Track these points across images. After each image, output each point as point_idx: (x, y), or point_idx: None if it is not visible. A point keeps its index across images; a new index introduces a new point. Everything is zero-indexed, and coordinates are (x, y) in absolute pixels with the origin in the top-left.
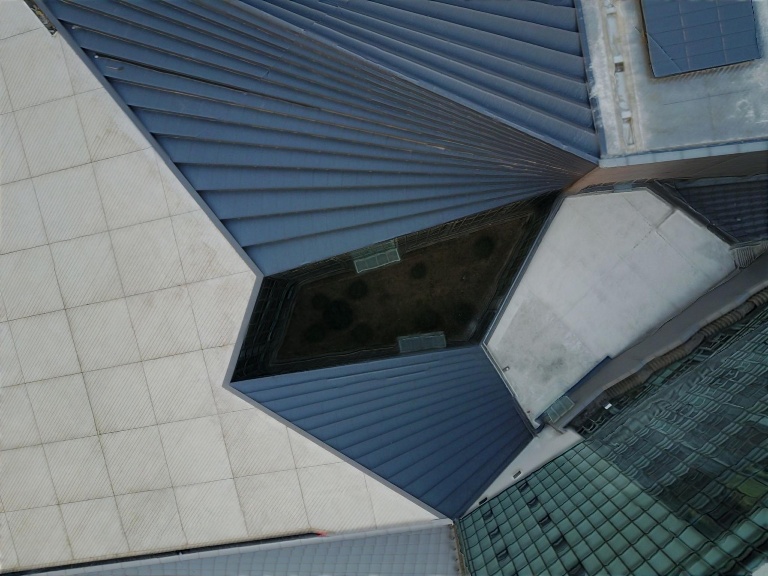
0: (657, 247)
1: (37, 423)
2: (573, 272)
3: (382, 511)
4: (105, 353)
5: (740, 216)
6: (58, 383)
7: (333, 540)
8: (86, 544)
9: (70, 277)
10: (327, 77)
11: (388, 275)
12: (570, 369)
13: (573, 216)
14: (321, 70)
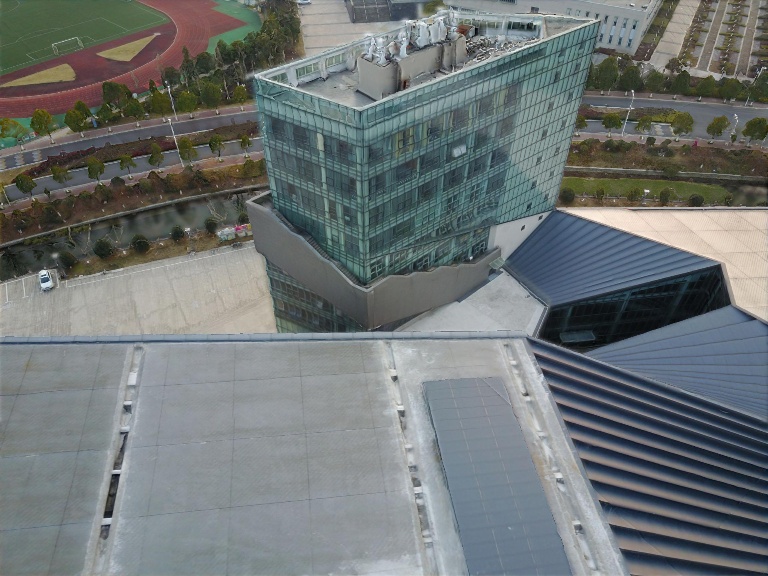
0: None
1: None
2: None
3: (598, 215)
4: None
5: None
6: None
7: None
8: (762, 216)
9: None
10: (755, 410)
11: None
12: (484, 296)
13: None
14: (763, 413)
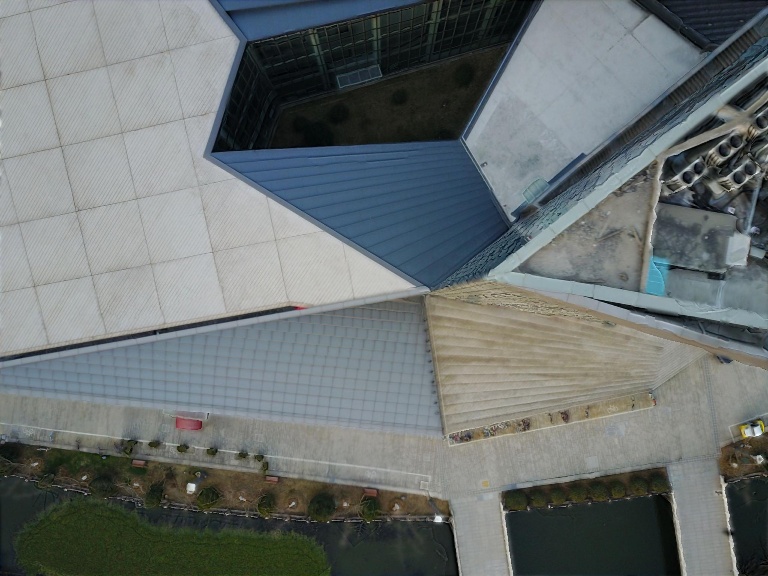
0: (632, 49)
1: (14, 201)
2: (551, 71)
3: (360, 281)
4: (85, 125)
5: (711, 22)
6: (36, 158)
7: (311, 312)
8: (62, 327)
9: (51, 46)
10: None
11: (370, 100)
12: (546, 165)
13: (552, 17)
14: None
